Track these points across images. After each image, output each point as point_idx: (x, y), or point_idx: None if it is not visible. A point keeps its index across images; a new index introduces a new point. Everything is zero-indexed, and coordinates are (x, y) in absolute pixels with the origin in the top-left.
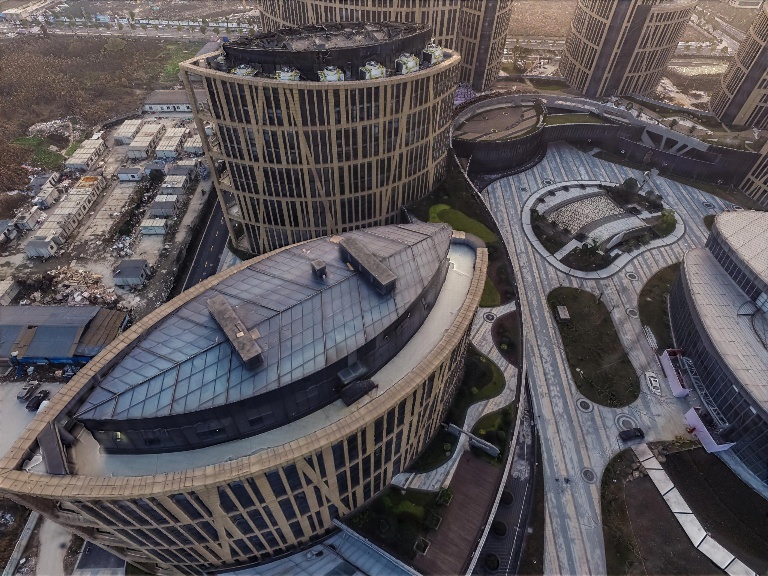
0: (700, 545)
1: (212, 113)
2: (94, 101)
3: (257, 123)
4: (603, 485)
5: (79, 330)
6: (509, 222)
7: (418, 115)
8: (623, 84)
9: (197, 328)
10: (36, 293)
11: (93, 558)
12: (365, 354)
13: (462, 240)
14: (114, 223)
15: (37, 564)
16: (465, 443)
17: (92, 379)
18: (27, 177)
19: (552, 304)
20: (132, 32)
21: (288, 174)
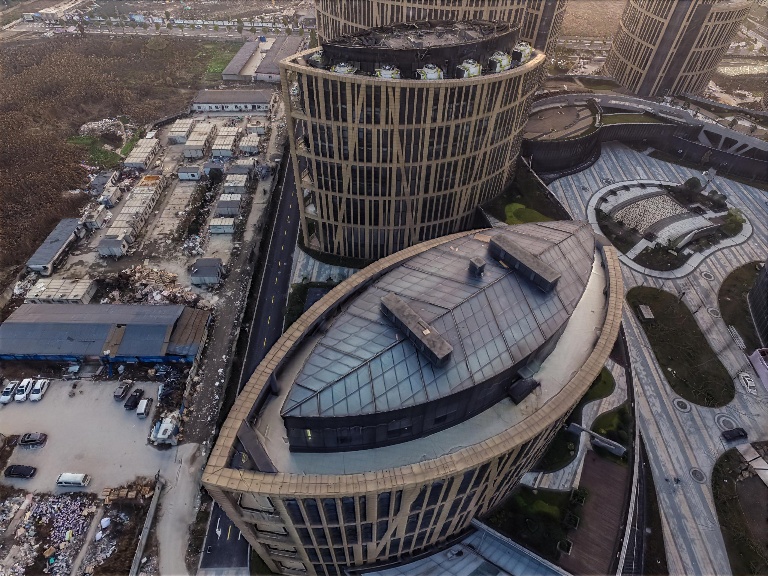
0: None
1: (307, 111)
2: (141, 100)
3: (353, 121)
4: (714, 485)
5: (168, 329)
6: None
7: (506, 114)
8: (676, 84)
9: (373, 326)
10: (115, 292)
11: (215, 557)
12: None
13: None
14: (180, 222)
15: (159, 563)
16: (587, 442)
17: (270, 377)
18: (86, 176)
19: (632, 303)
20: (168, 32)
21: (376, 173)
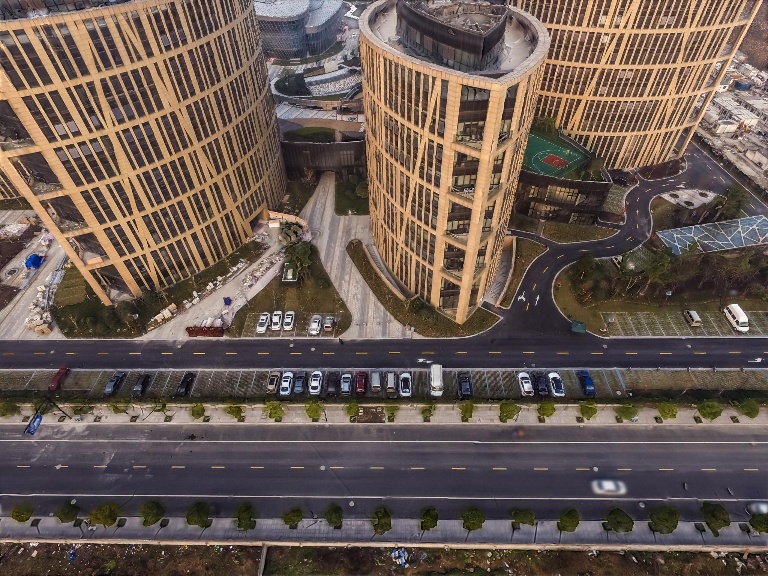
0: None
1: None
2: None
3: None
4: None
5: None
6: None
7: None
8: None
9: None
10: None
11: None
12: None
13: None
14: None
15: None
16: None
17: None
18: None
19: None
20: None
21: None
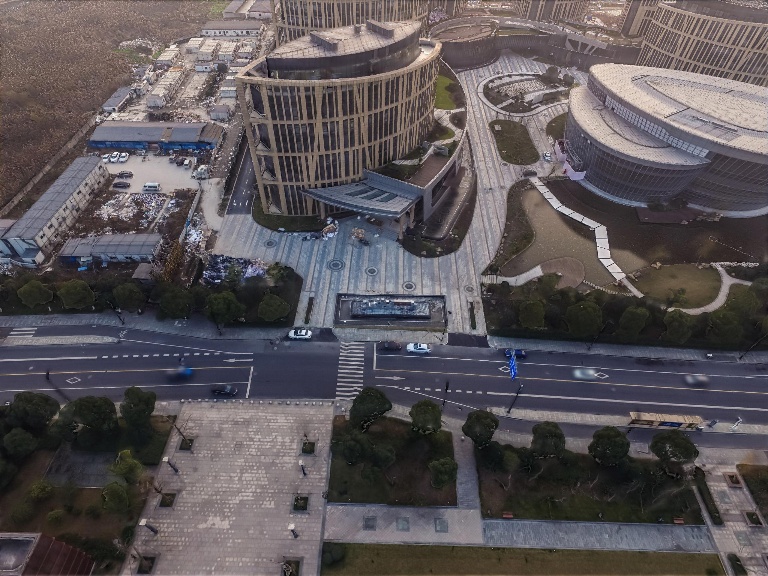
0: (558, 208)
1: None
2: (162, 29)
3: None
4: (510, 190)
5: (199, 129)
6: (468, 91)
7: None
8: (555, 10)
9: (306, 43)
10: (161, 121)
11: (233, 211)
12: (381, 57)
13: (428, 42)
14: (200, 92)
15: (204, 214)
16: (431, 152)
17: (261, 63)
18: None
19: (492, 126)
20: None
21: None
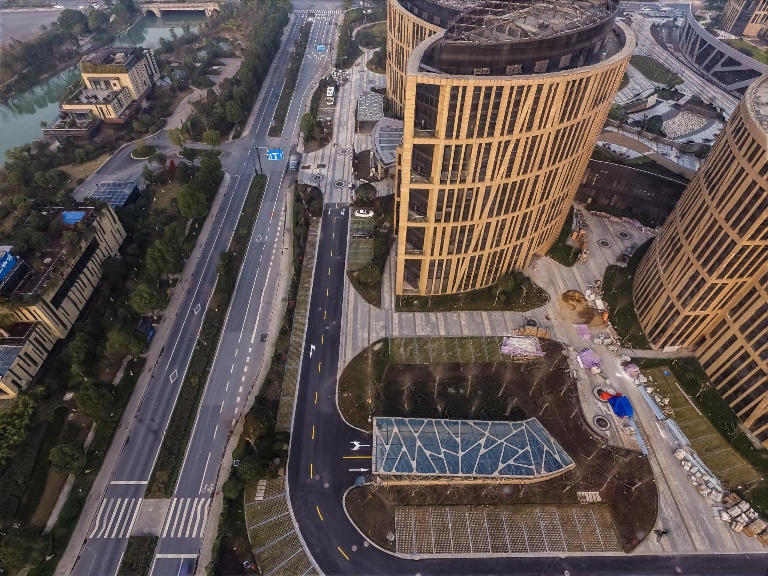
0: None
1: None
2: None
3: None
4: None
5: None
6: None
7: None
8: None
9: None
10: None
11: None
12: None
13: None
14: None
15: None
16: (707, 17)
17: None
18: None
19: None
20: None
21: None
